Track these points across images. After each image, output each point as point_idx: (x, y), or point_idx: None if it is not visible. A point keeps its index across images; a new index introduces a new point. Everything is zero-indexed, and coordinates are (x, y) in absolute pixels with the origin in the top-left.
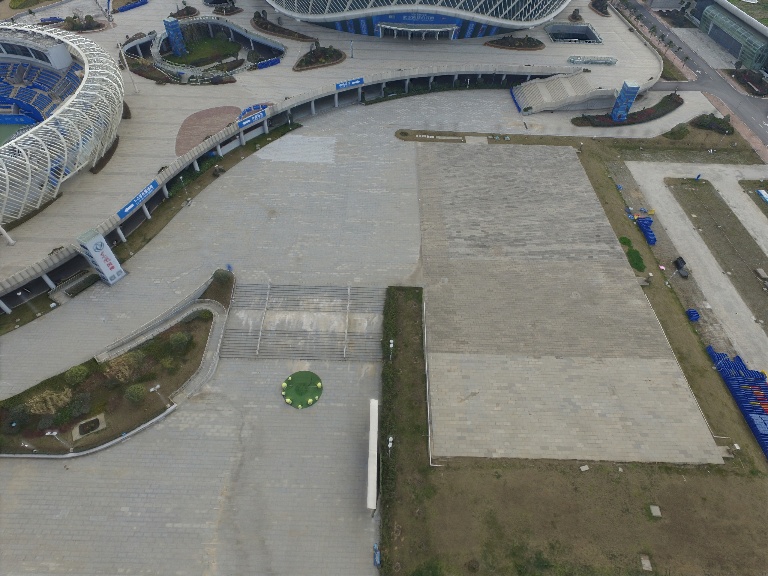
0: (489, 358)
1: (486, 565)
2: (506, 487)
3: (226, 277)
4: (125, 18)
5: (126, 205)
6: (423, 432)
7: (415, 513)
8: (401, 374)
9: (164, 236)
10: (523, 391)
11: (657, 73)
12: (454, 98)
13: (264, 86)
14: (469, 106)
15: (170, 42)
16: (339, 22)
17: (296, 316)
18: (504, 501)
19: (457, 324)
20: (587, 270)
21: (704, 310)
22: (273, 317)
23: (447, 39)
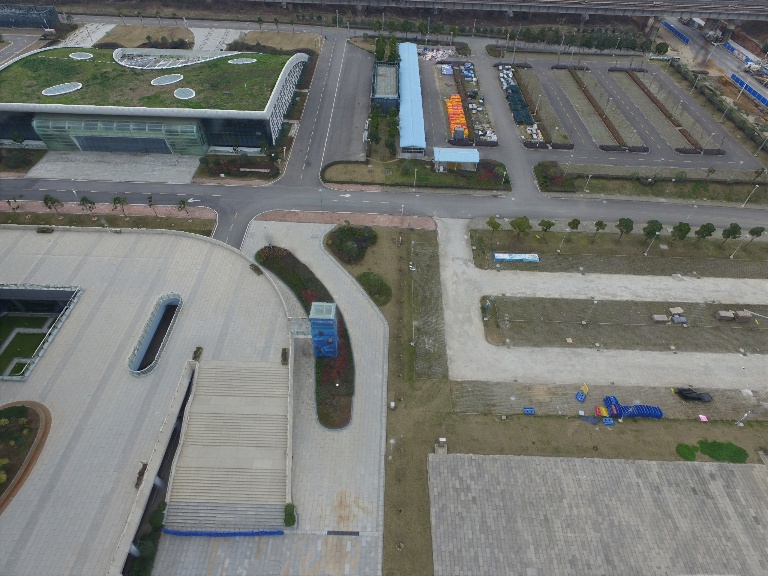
0: None
1: None
2: None
3: None
4: None
5: None
6: None
7: None
8: None
9: None
10: None
11: (231, 254)
12: None
13: None
14: None
15: None
16: None
17: None
18: None
19: None
20: None
21: (759, 399)
22: None
23: None
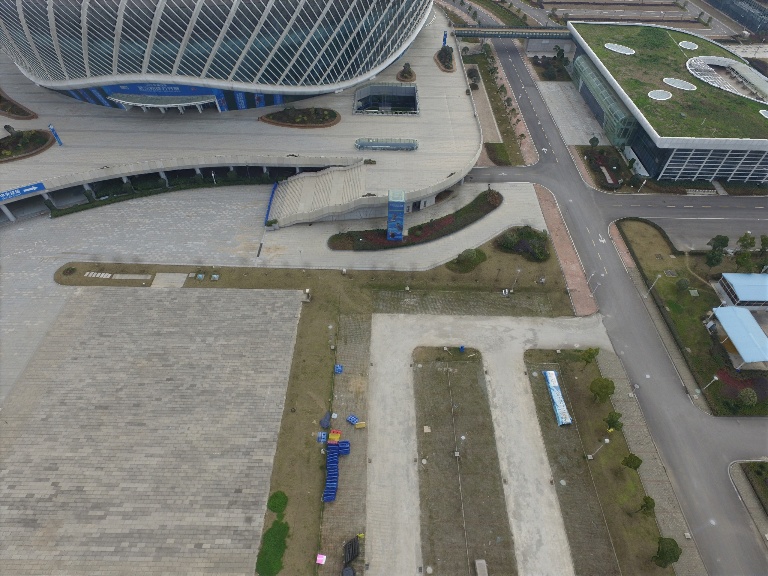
0: None
1: None
2: None
3: None
4: None
5: None
6: None
7: None
8: None
9: None
10: None
11: None
12: (187, 202)
13: None
14: (200, 216)
15: None
16: (72, 91)
17: None
18: None
19: None
20: None
21: None
22: None
23: (214, 111)
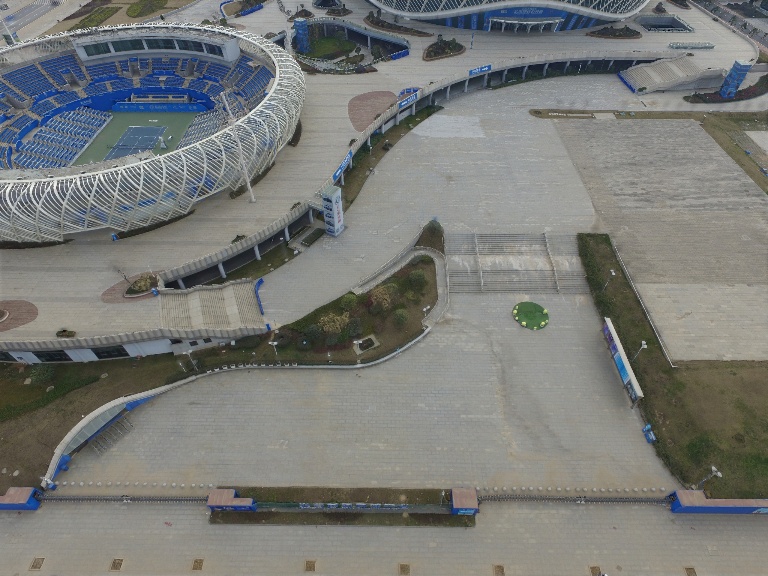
0: (690, 287)
1: (750, 438)
2: (744, 382)
3: (439, 227)
4: (250, 21)
5: (337, 170)
6: (655, 343)
7: (672, 402)
8: (616, 301)
9: (363, 198)
10: (730, 311)
11: (754, 55)
12: (569, 82)
13: (404, 74)
14: (586, 89)
15: (297, 40)
16: (450, 18)
17: (504, 259)
18: (747, 392)
19: (651, 261)
20: (748, 218)
21: None
22: (484, 260)
23: (550, 31)
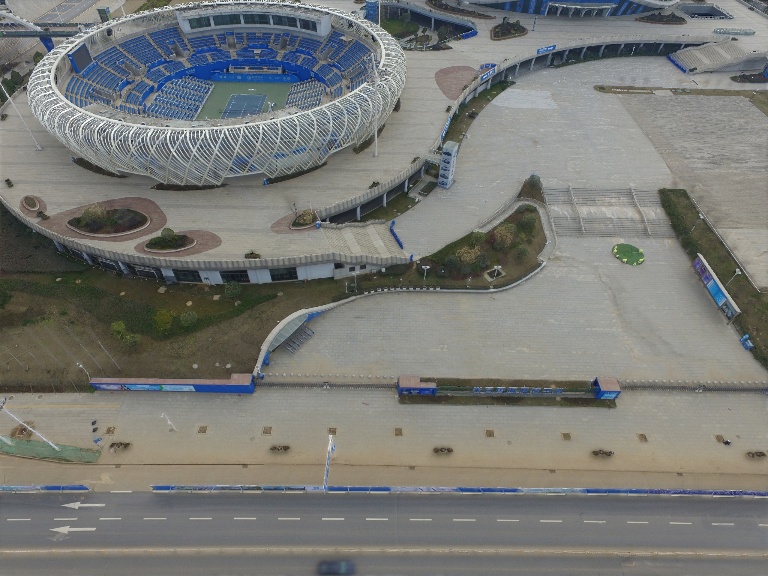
0: (764, 231)
1: None
2: None
3: None
4: (319, 2)
5: (443, 131)
6: (741, 274)
7: (763, 319)
8: (701, 242)
9: (463, 158)
10: None
11: None
12: (624, 63)
13: (478, 51)
14: (640, 69)
15: None
16: (510, 3)
17: (597, 209)
18: None
19: (726, 211)
20: None
21: None
22: (581, 209)
23: (602, 16)
